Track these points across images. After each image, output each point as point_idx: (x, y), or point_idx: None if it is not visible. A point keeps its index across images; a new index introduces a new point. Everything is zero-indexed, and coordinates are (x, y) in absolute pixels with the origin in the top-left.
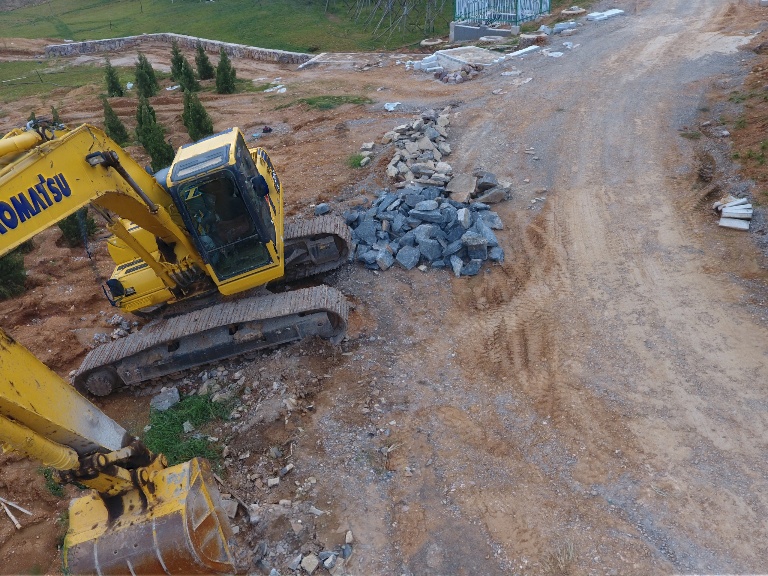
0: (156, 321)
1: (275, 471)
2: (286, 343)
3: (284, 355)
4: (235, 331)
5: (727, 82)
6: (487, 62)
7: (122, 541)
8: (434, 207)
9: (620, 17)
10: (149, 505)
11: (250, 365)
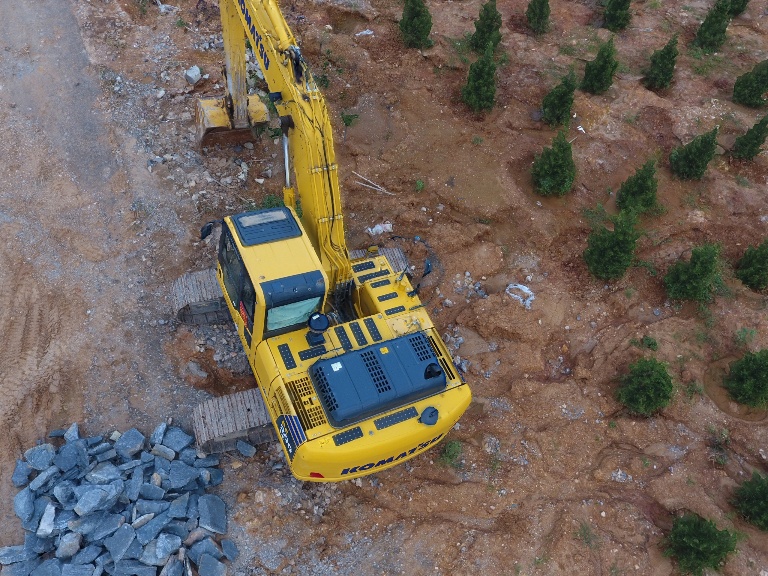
0: None
1: None
2: None
3: None
4: None
5: None
6: None
7: None
8: None
9: None
10: None
11: None
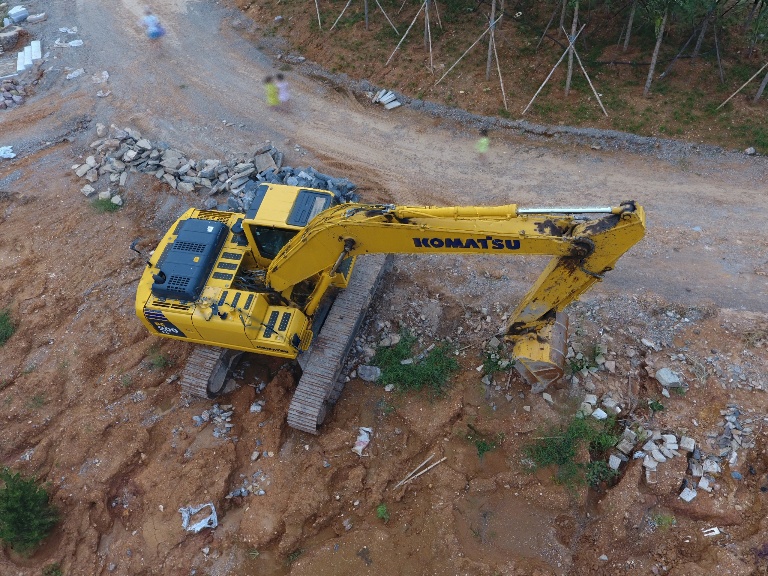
0: None
1: (482, 317)
2: None
3: None
4: None
5: (241, 23)
6: (6, 73)
7: (557, 337)
8: None
9: None
10: None
11: (377, 317)
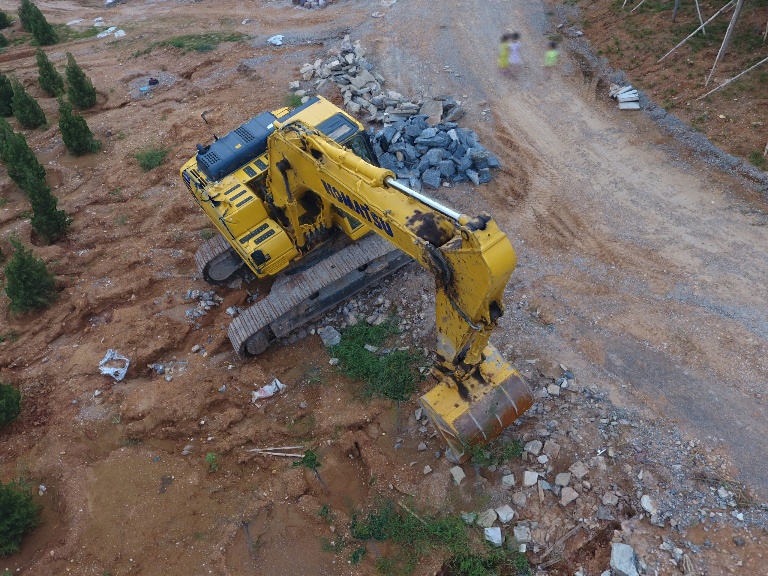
0: (285, 278)
1: None
2: (403, 266)
3: (413, 275)
4: (365, 267)
5: None
6: None
7: (487, 405)
8: (435, 133)
9: None
10: (486, 379)
11: (384, 291)
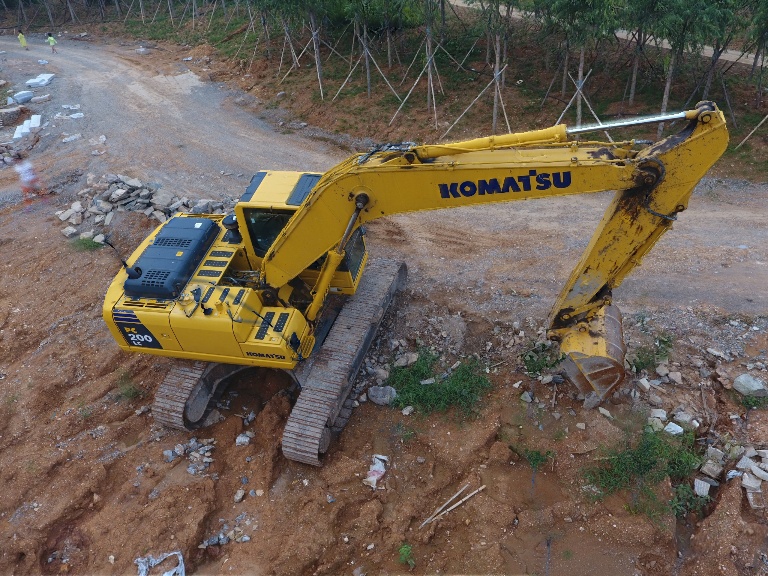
0: (307, 363)
1: (514, 332)
2: None
3: None
4: None
5: (244, 100)
6: (2, 141)
7: (612, 331)
8: None
9: (59, 79)
10: (593, 316)
11: (389, 335)
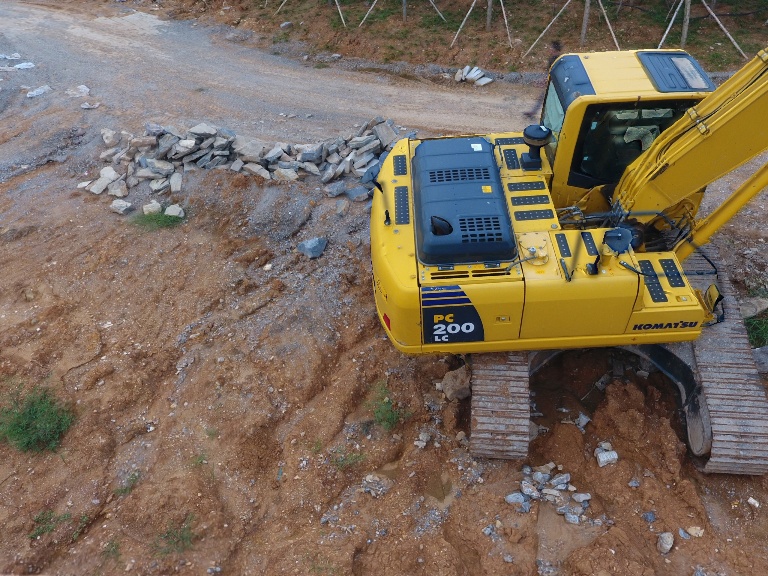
0: None
1: None
2: None
3: None
4: None
5: (238, 36)
6: None
7: None
8: None
9: None
10: None
11: None
